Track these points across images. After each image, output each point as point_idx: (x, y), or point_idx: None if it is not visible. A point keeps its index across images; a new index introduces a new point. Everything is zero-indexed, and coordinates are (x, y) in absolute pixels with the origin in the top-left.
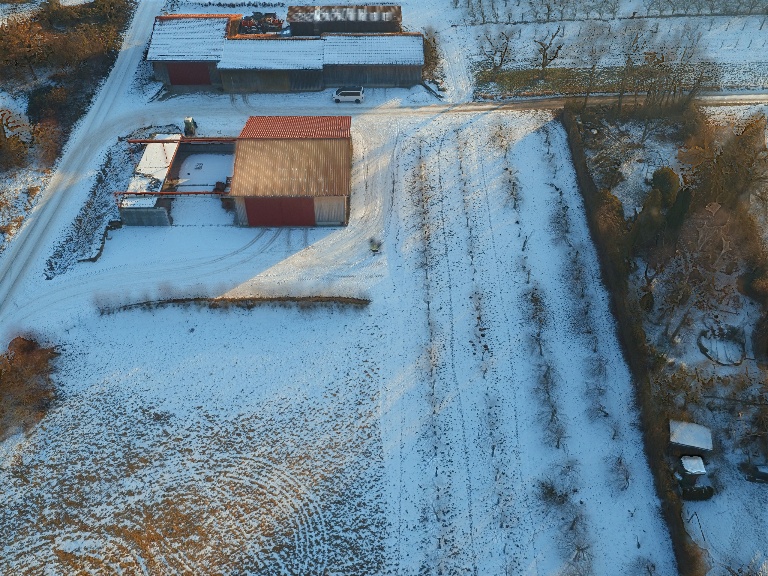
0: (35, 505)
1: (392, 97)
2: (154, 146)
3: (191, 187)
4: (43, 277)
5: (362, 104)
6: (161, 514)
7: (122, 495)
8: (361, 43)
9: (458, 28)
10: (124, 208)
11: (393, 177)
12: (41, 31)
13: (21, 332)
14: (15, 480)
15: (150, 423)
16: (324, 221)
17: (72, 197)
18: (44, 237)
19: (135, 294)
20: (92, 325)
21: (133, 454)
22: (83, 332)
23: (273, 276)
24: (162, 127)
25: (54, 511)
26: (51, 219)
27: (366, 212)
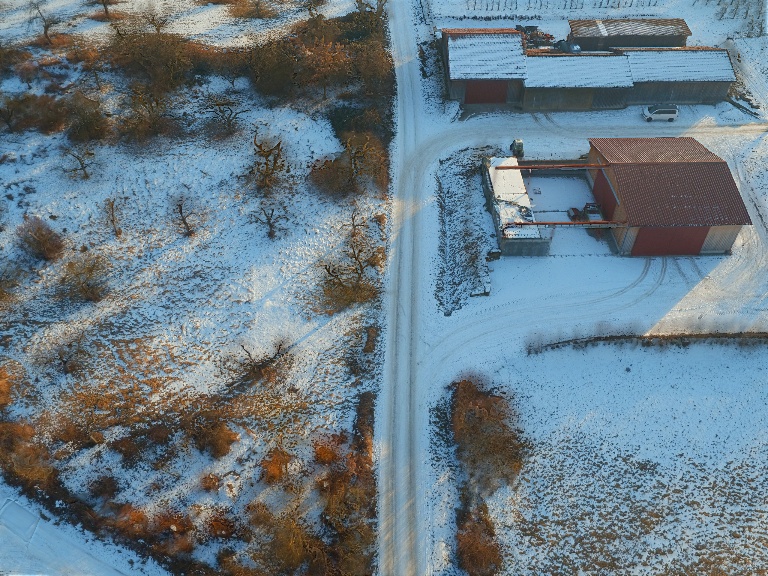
0: (566, 566)
1: (702, 115)
2: (497, 171)
3: (543, 213)
4: (441, 313)
5: (676, 123)
6: (706, 575)
7: (653, 554)
8: (666, 59)
9: (736, 41)
10: (509, 239)
11: (752, 201)
12: (307, 47)
13: (450, 374)
14: (529, 538)
15: (639, 473)
16: (709, 250)
17: (424, 225)
18: (417, 269)
19: (553, 331)
20: (521, 365)
21: (639, 508)
22: (513, 373)
23: (689, 310)
24: (478, 149)
25: (590, 573)
26: (414, 249)
27: (744, 239)
